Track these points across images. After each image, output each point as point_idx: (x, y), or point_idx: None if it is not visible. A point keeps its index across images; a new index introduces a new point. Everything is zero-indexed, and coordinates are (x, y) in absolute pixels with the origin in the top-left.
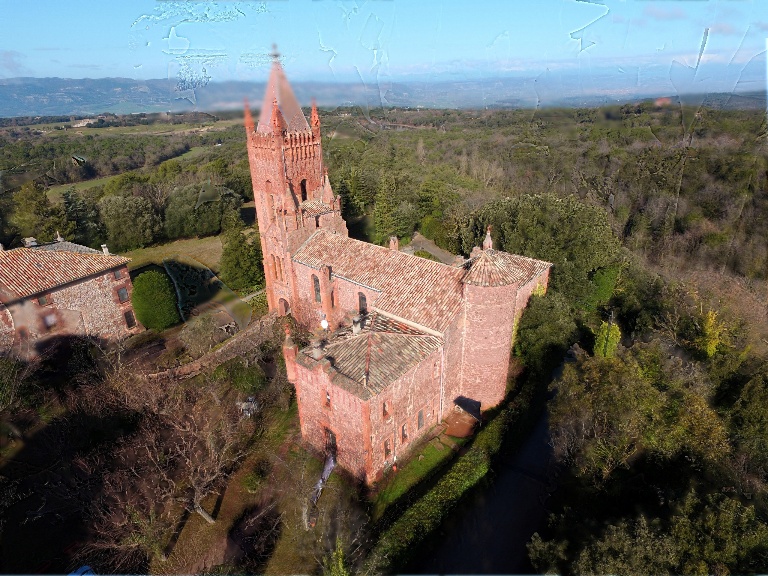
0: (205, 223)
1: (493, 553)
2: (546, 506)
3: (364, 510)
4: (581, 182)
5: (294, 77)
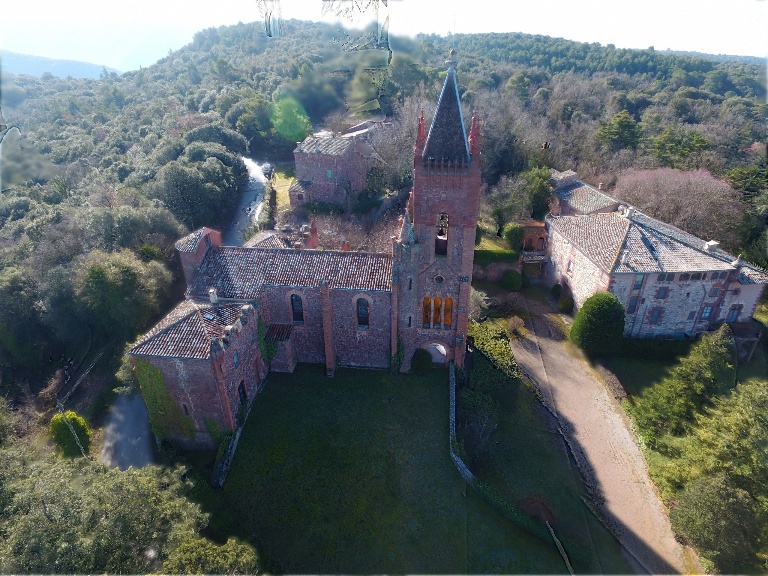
0: None
1: None
2: None
3: None
4: None
5: (330, 87)
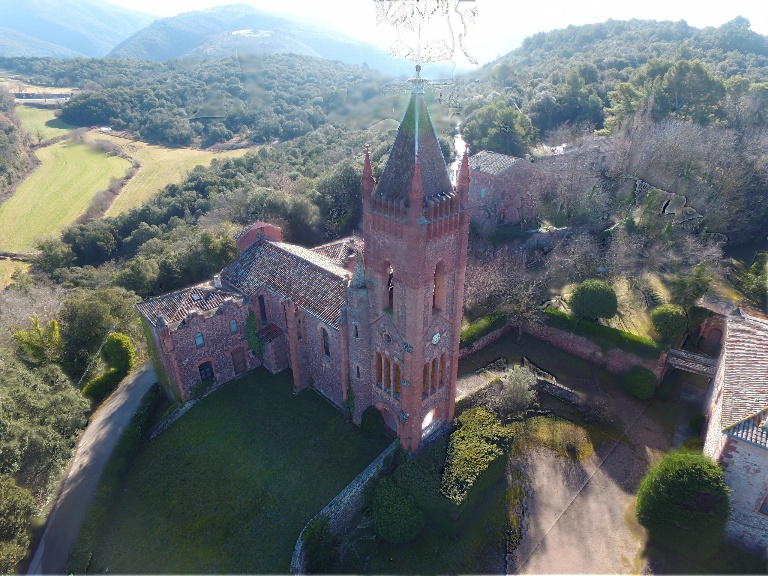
0: None
1: None
2: None
3: None
4: None
5: (377, 101)
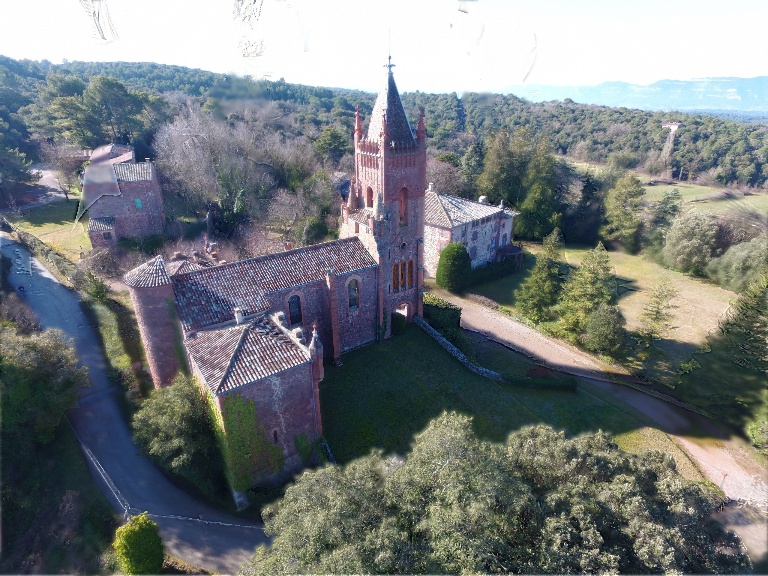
0: (740, 280)
1: None
2: None
3: None
4: None
5: None
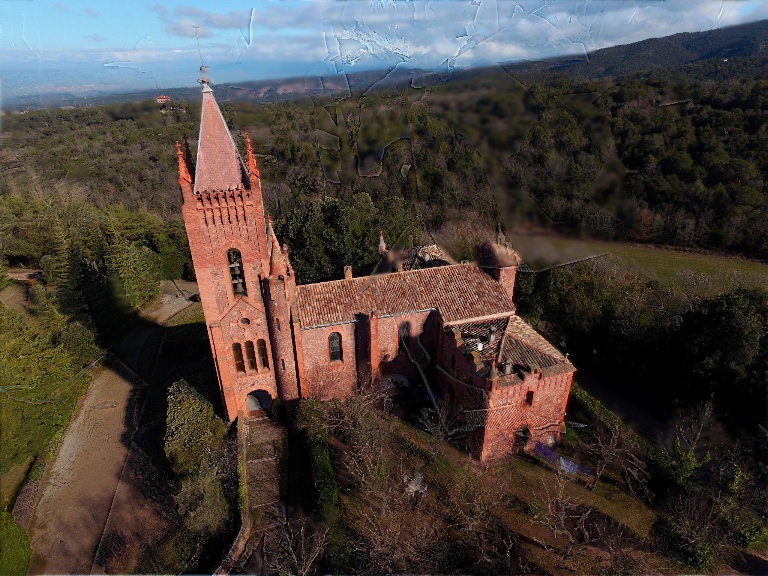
0: None
1: (628, 412)
2: (594, 379)
3: (581, 453)
4: (294, 182)
5: None
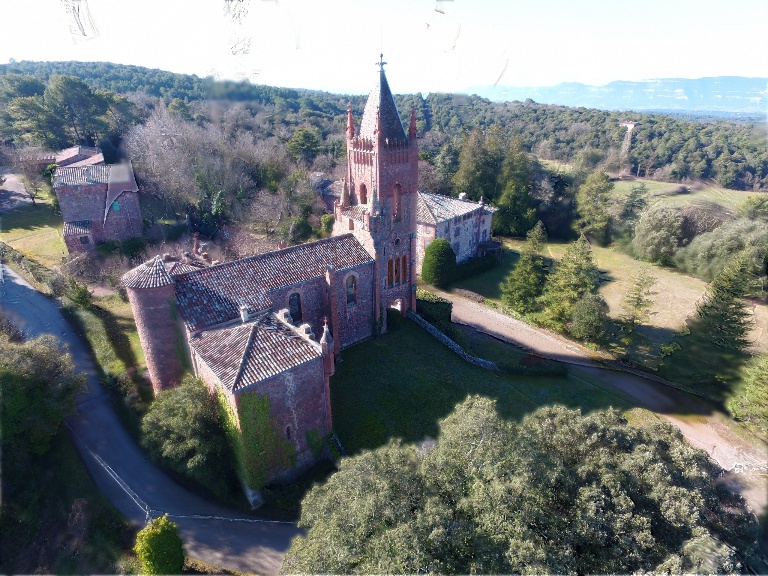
0: (706, 268)
1: None
2: None
3: None
4: None
5: None
